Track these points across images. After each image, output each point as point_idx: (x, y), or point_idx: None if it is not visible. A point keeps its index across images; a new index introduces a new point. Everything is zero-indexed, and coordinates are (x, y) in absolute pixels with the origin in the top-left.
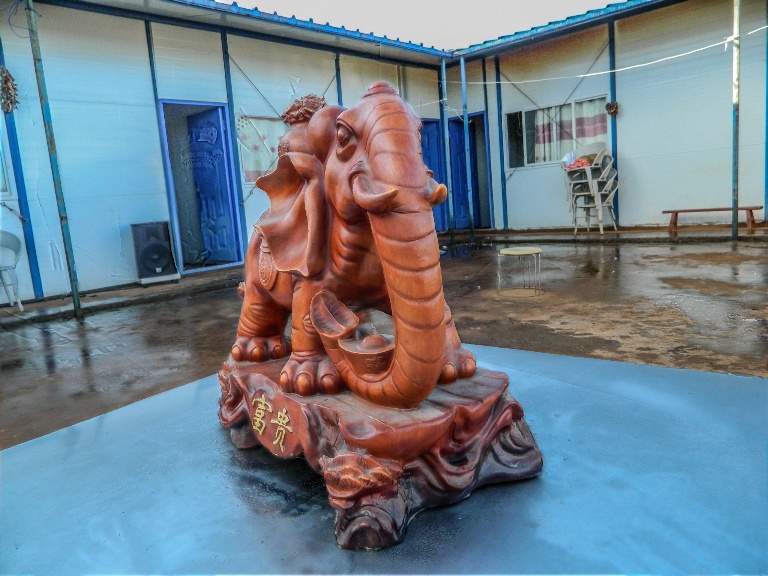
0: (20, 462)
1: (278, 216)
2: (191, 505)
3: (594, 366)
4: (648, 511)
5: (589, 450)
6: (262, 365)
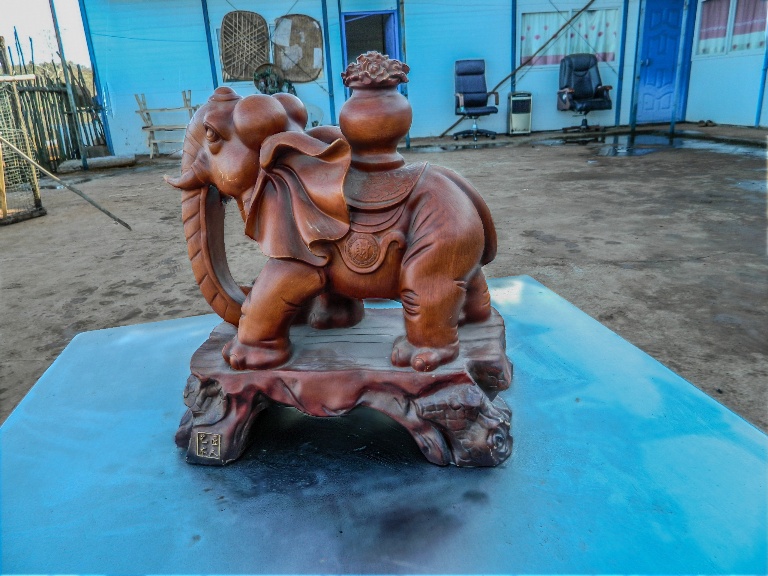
0: (531, 306)
1: None
2: None
3: None
4: (88, 456)
5: (142, 492)
6: None
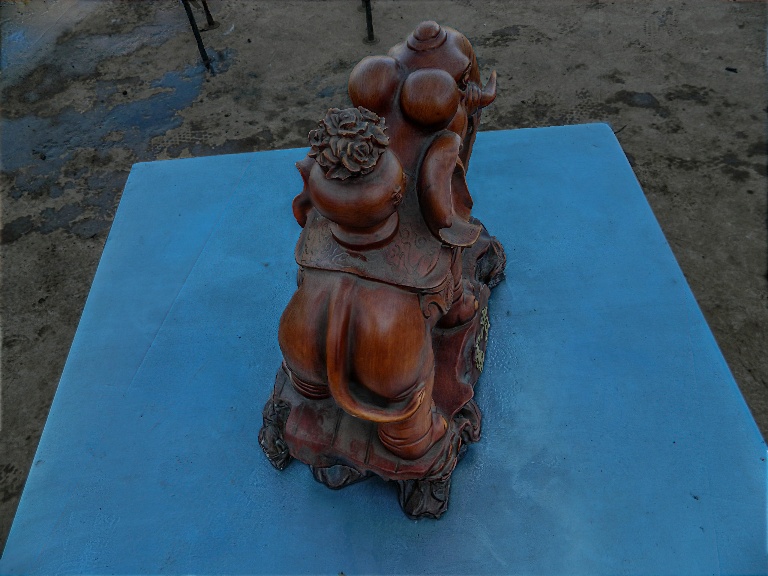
0: None
1: (445, 229)
2: (550, 381)
3: (121, 286)
4: None
5: None
6: (435, 394)
